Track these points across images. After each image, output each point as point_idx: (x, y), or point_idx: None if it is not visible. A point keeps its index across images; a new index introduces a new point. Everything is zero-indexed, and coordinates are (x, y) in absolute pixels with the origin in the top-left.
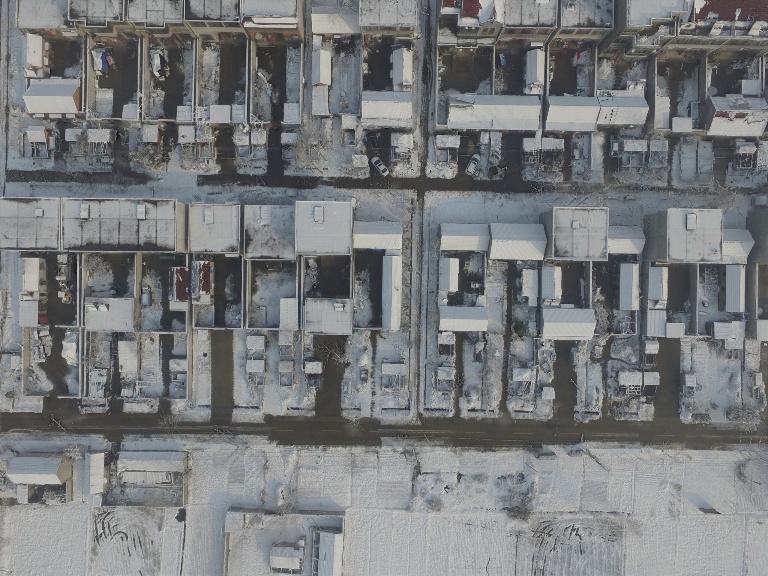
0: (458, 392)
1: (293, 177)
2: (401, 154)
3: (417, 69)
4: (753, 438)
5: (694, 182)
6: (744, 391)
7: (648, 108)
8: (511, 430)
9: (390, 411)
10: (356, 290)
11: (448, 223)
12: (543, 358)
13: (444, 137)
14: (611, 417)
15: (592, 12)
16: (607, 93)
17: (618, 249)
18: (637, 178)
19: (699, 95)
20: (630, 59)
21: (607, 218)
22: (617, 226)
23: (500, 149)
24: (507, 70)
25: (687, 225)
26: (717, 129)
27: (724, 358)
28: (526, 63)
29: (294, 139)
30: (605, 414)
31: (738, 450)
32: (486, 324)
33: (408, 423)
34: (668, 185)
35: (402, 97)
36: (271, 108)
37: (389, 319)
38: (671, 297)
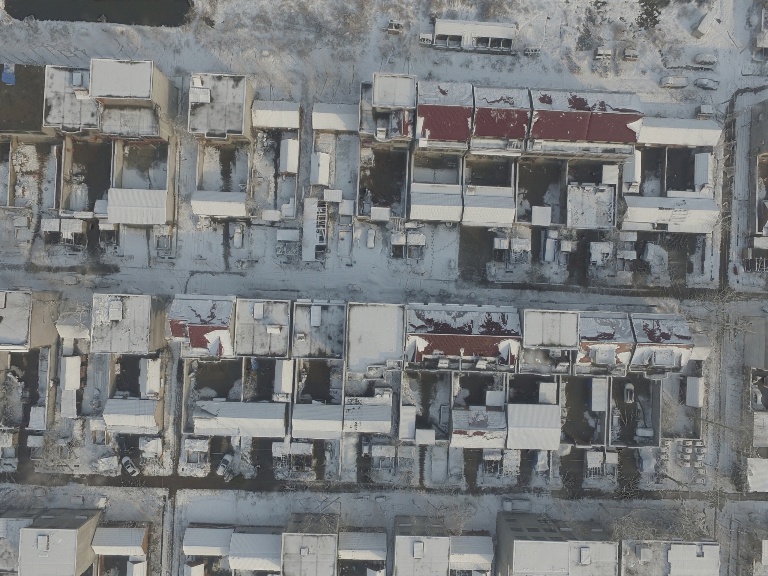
0: None
1: (44, 474)
2: (148, 459)
3: (171, 369)
4: None
5: (445, 483)
6: None
7: (390, 422)
8: None
9: None
10: None
11: (194, 528)
12: None
13: (192, 442)
14: None
15: (323, 343)
16: (355, 400)
17: (362, 557)
18: (388, 479)
19: (450, 399)
20: None
21: (336, 545)
22: (362, 533)
23: None
24: (262, 370)
25: (413, 554)
26: (458, 443)
27: None
28: (275, 370)
29: (40, 443)
30: None
31: None
32: None
33: None
34: (420, 485)
35: (145, 408)
36: (22, 406)
37: None
38: None
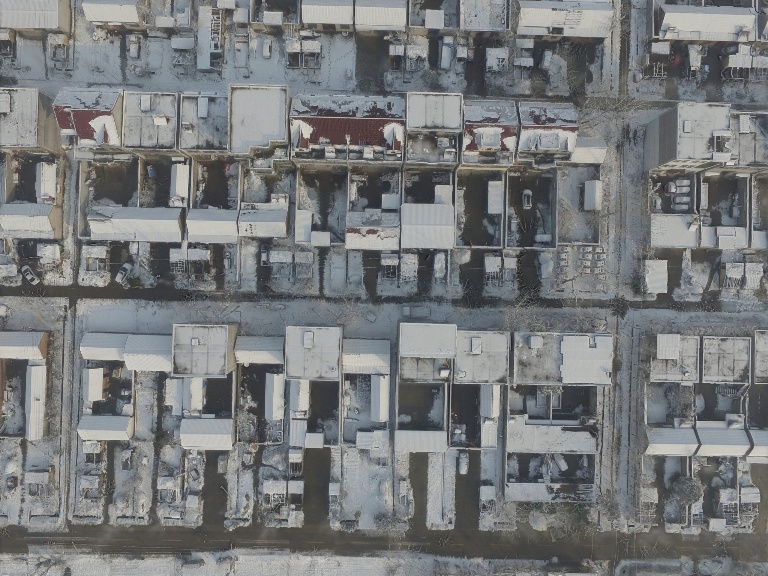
0: (108, 499)
1: None
2: (45, 265)
3: (69, 179)
4: (402, 545)
5: (344, 291)
6: (395, 497)
7: (284, 223)
8: (160, 537)
9: (40, 518)
10: (6, 397)
11: (92, 333)
12: (193, 465)
13: (90, 248)
14: (261, 524)
15: (211, 134)
16: (252, 206)
17: (260, 360)
18: (288, 287)
19: None
20: (278, 171)
21: (226, 336)
22: (260, 337)
23: (148, 259)
24: (160, 180)
25: (304, 343)
26: (353, 244)
27: (375, 465)
28: None
29: None
30: (255, 521)
31: (387, 557)
32: (125, 434)
33: (56, 530)
34: (320, 294)
35: (40, 211)
36: None
37: (28, 429)
38: (322, 404)
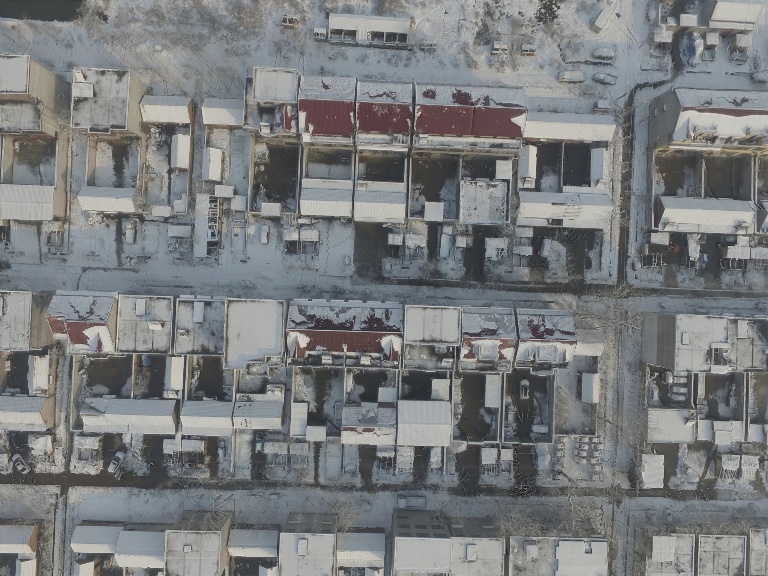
0: None
1: None
2: (37, 456)
3: (62, 366)
4: None
5: (340, 480)
6: None
7: (280, 419)
8: None
9: None
10: None
11: (83, 526)
12: None
13: (82, 439)
14: None
15: (206, 339)
16: (247, 397)
17: (253, 554)
18: (283, 476)
19: None
20: None
21: (219, 542)
22: (254, 530)
23: None
24: (155, 366)
25: (298, 551)
26: (349, 439)
27: None
28: None
29: None
30: None
31: None
32: None
33: None
34: (315, 482)
35: (32, 405)
36: None
37: None
38: None
